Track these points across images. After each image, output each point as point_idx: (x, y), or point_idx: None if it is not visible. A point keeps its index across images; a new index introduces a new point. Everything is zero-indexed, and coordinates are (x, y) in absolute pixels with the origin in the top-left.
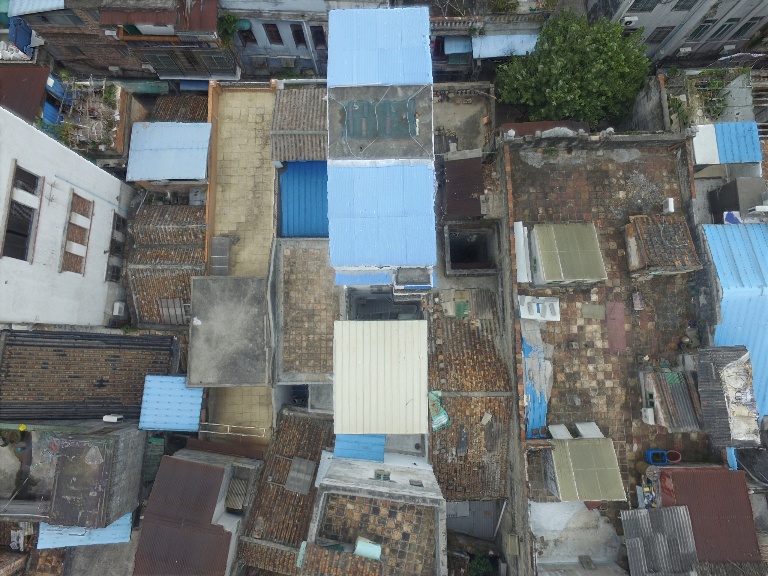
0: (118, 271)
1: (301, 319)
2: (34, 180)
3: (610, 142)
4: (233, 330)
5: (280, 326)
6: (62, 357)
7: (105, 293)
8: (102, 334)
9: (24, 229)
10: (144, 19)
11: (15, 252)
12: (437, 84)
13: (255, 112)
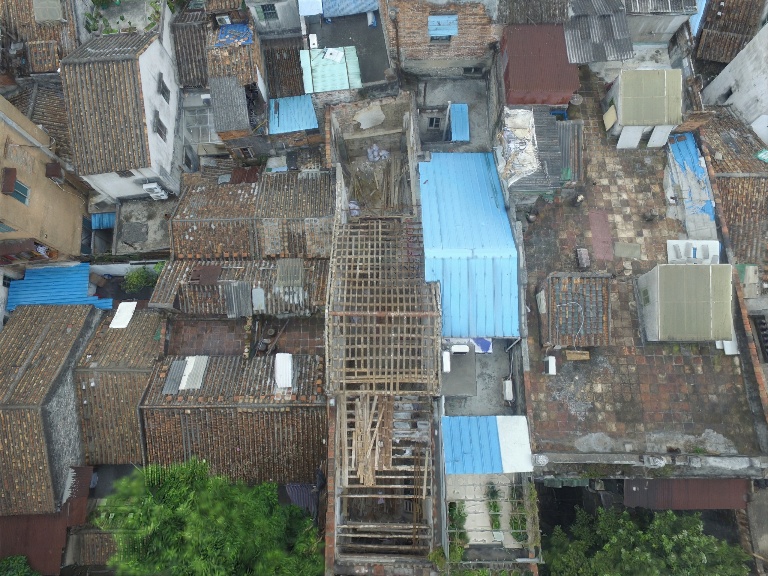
0: None
1: None
2: None
3: None
4: None
5: None
6: None
7: None
8: None
9: None
10: None
11: None
12: None
13: None
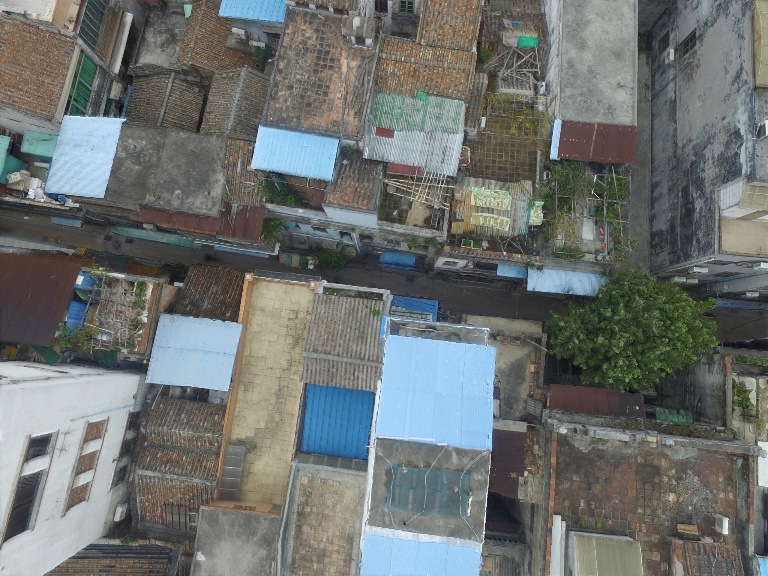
0: (125, 468)
1: (310, 558)
2: (47, 437)
3: None
4: (237, 572)
5: (287, 563)
6: (55, 569)
7: (108, 501)
8: (100, 543)
9: (30, 494)
10: (186, 222)
11: (16, 528)
12: (486, 317)
13: (289, 307)
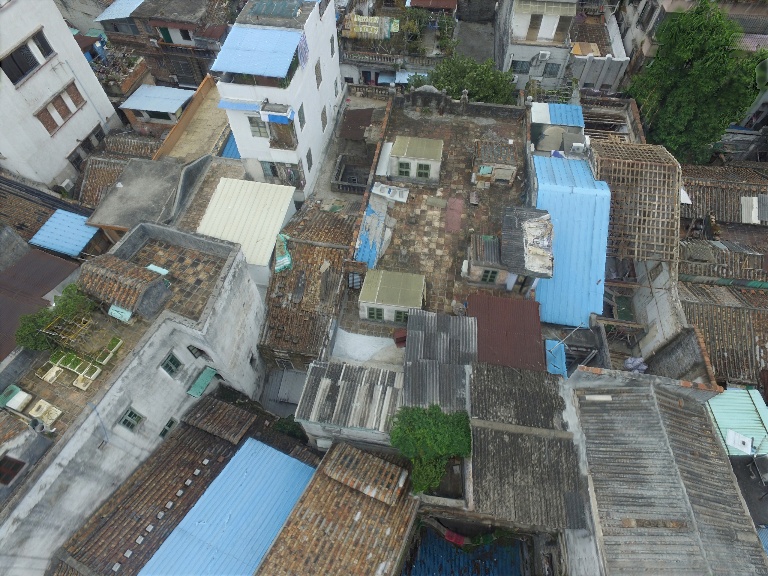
0: None
1: (205, 205)
2: (49, 51)
3: (469, 106)
4: (145, 194)
5: (186, 208)
6: (2, 198)
7: (62, 167)
8: (43, 194)
9: (25, 69)
10: (176, 26)
11: (9, 73)
12: None
13: None
